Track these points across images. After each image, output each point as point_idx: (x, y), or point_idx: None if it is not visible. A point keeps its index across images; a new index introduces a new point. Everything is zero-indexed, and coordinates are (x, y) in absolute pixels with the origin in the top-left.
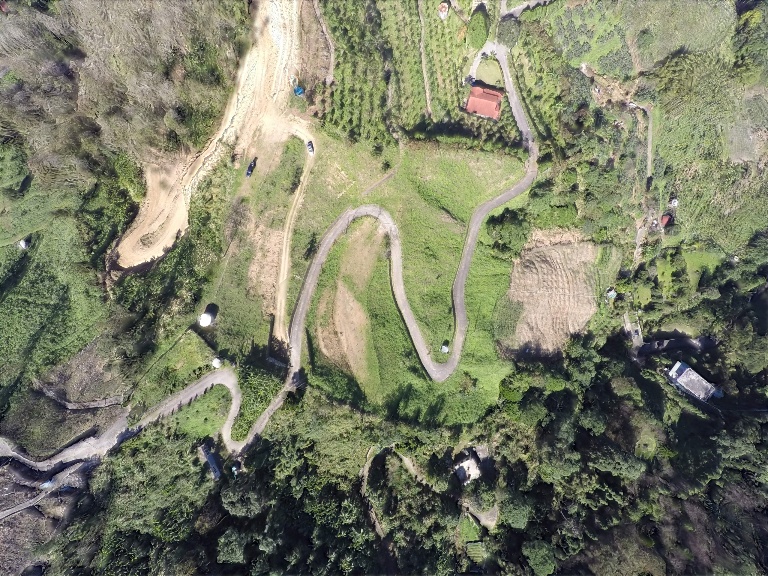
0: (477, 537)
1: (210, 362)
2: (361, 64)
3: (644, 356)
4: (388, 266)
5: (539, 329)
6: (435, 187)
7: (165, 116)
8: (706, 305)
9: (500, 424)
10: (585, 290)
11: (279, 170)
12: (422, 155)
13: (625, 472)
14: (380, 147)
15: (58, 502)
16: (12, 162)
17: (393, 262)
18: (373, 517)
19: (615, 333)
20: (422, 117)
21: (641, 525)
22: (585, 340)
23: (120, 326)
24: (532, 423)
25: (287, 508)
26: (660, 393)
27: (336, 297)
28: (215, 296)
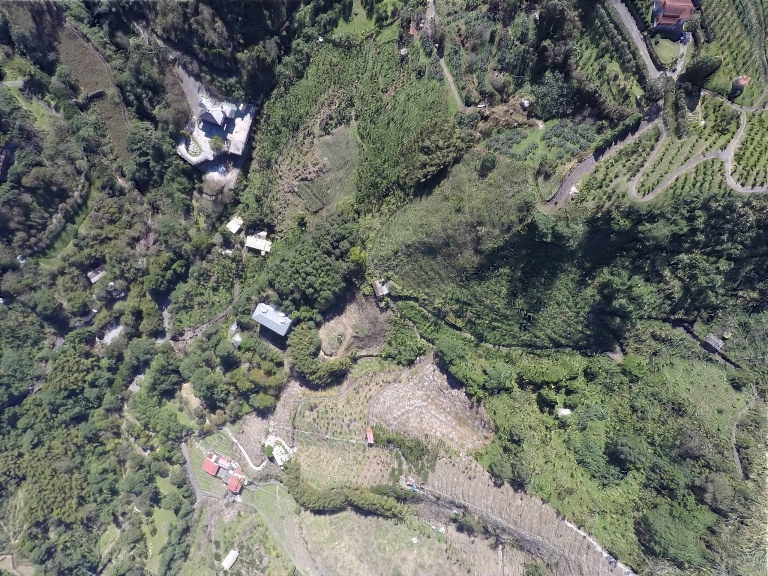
0: None
1: None
2: None
3: None
4: None
5: None
6: None
7: None
8: None
9: None
10: None
11: None
12: None
13: None
14: None
15: None
16: None
17: None
18: None
19: None
20: None
21: None
22: None
23: None
24: None
25: None
26: None
27: None
28: None
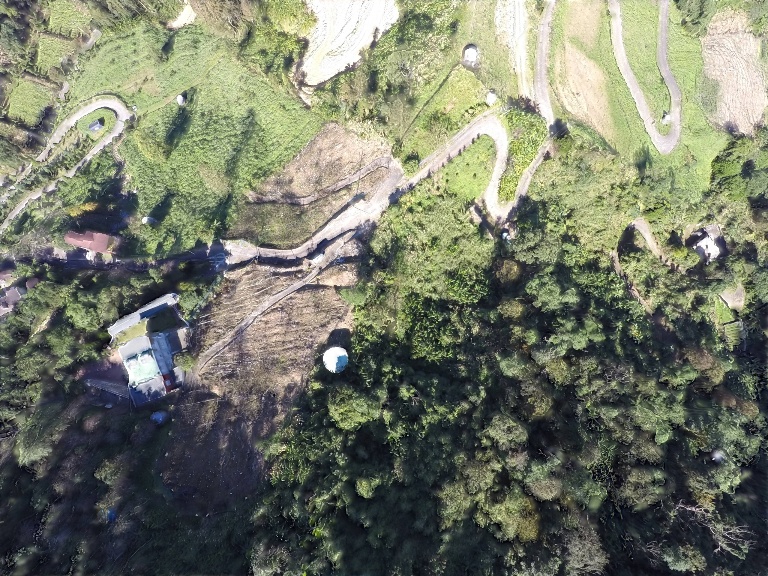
0: (731, 317)
1: (482, 99)
2: None
3: None
4: (608, 26)
5: (731, 112)
6: None
7: None
8: None
9: (720, 206)
10: (758, 79)
11: None
12: None
13: None
14: None
15: (343, 268)
16: (145, 35)
17: (612, 22)
18: (636, 295)
19: None
20: None
21: None
22: None
23: (365, 90)
24: (760, 191)
25: (564, 276)
26: None
27: (565, 58)
28: (470, 38)
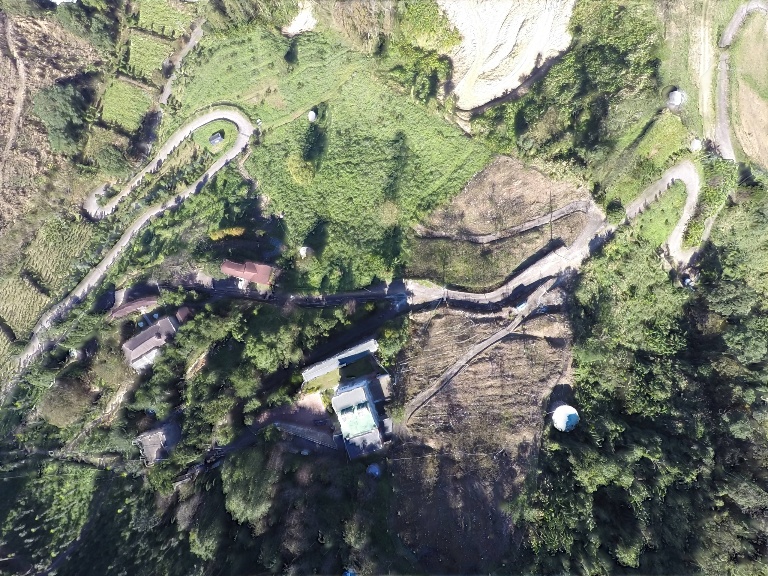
0: None
1: (685, 145)
2: None
3: None
4: None
5: None
6: None
7: None
8: None
9: None
10: None
11: None
12: None
13: None
14: None
15: (552, 319)
16: (263, 41)
17: None
18: None
19: None
20: None
21: None
22: None
23: None
24: None
25: None
26: None
27: (739, 96)
28: (670, 78)
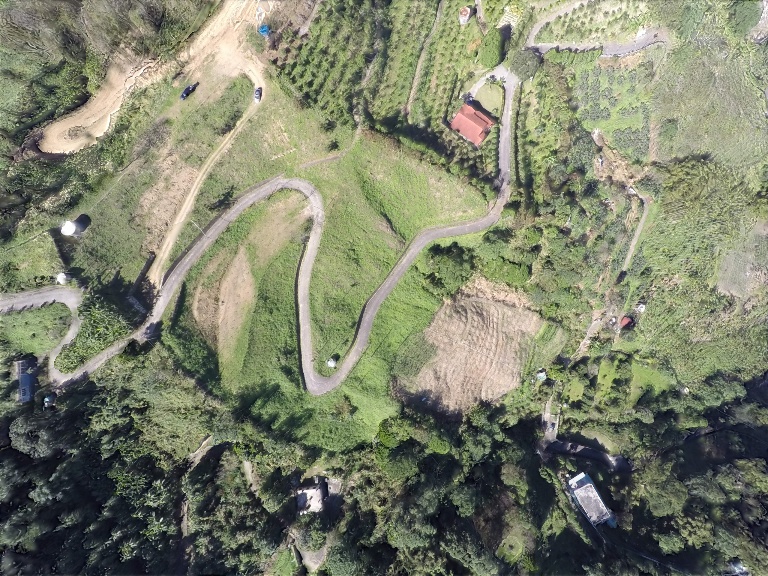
0: (291, 574)
1: (56, 275)
2: (346, 29)
3: (551, 453)
4: (301, 252)
5: (446, 382)
6: (384, 190)
7: (131, 8)
8: (637, 426)
9: (366, 464)
10: (512, 361)
11: (216, 104)
12: (379, 150)
13: (474, 567)
14: (333, 122)
15: None
16: None
17: (308, 250)
18: (184, 510)
19: (529, 417)
20: (397, 112)
21: None
22: (495, 412)
23: None
24: (396, 476)
25: (88, 464)
26: (551, 498)
27: (232, 262)
28: (93, 208)
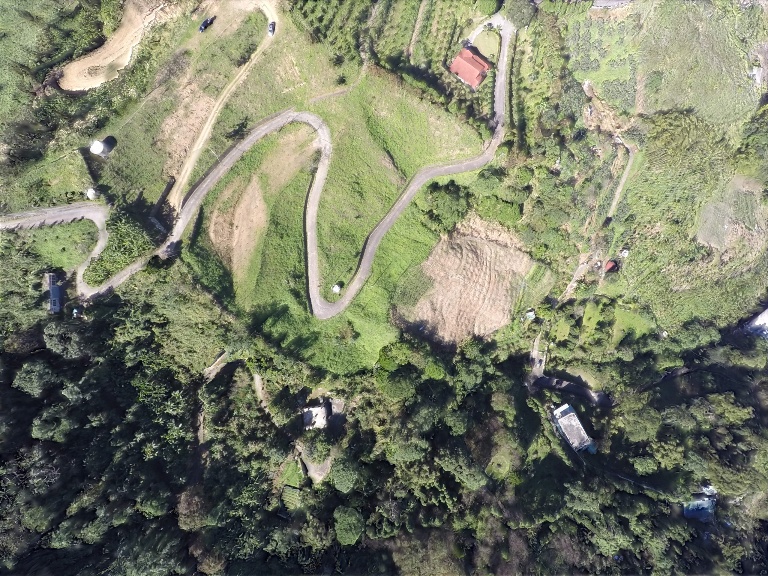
0: (298, 484)
1: (85, 191)
2: None
3: (538, 387)
4: (309, 182)
5: (442, 314)
6: (387, 127)
7: None
8: (618, 365)
9: (367, 388)
10: (504, 298)
11: (232, 37)
12: (383, 86)
13: (465, 479)
14: (341, 57)
15: None
16: None
17: (316, 180)
18: (200, 420)
19: (519, 353)
20: (400, 52)
21: (461, 536)
22: (486, 347)
23: (17, 125)
24: (395, 396)
25: (113, 371)
26: (537, 426)
27: (246, 190)
28: (118, 131)
